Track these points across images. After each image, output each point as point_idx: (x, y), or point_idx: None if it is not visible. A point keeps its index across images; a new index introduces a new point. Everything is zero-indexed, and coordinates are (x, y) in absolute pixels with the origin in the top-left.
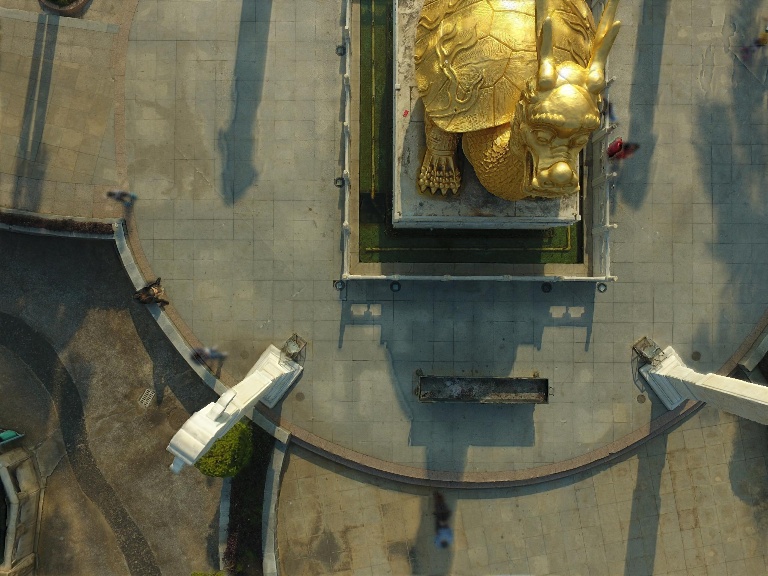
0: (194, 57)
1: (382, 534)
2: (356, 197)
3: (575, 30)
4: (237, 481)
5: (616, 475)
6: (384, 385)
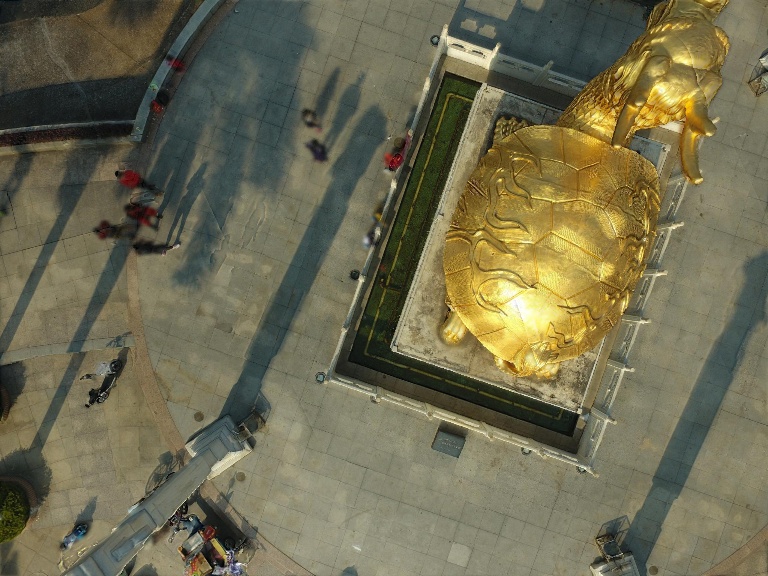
0: (767, 407)
1: None
2: None
3: (513, 221)
4: None
5: None
6: None
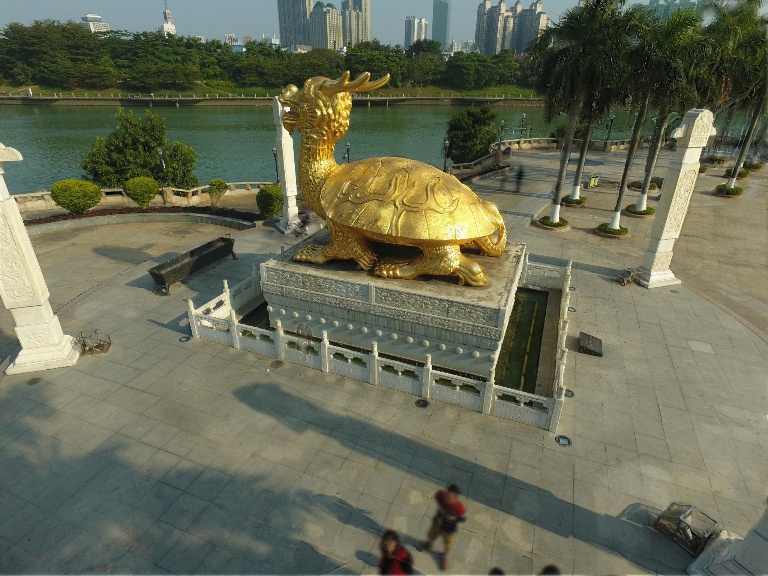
0: None
1: (164, 244)
2: None
3: None
4: (252, 213)
5: None
6: None
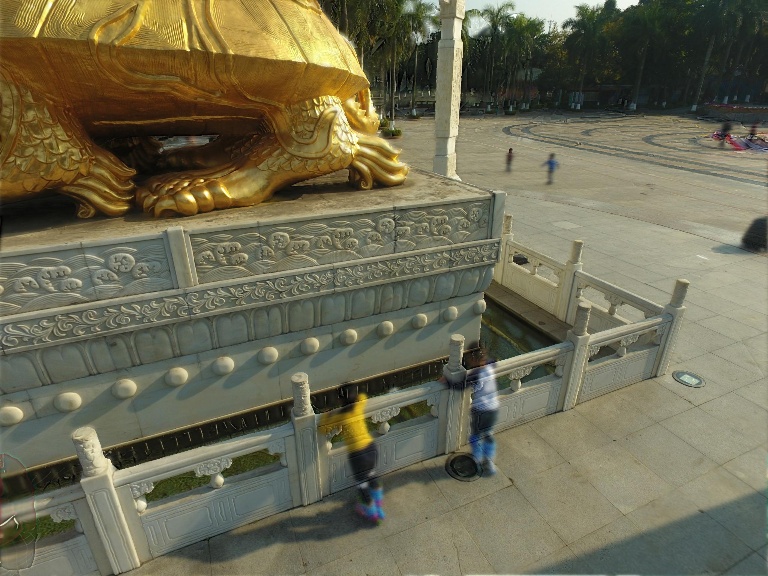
0: None
1: None
2: None
3: None
4: None
5: None
6: None
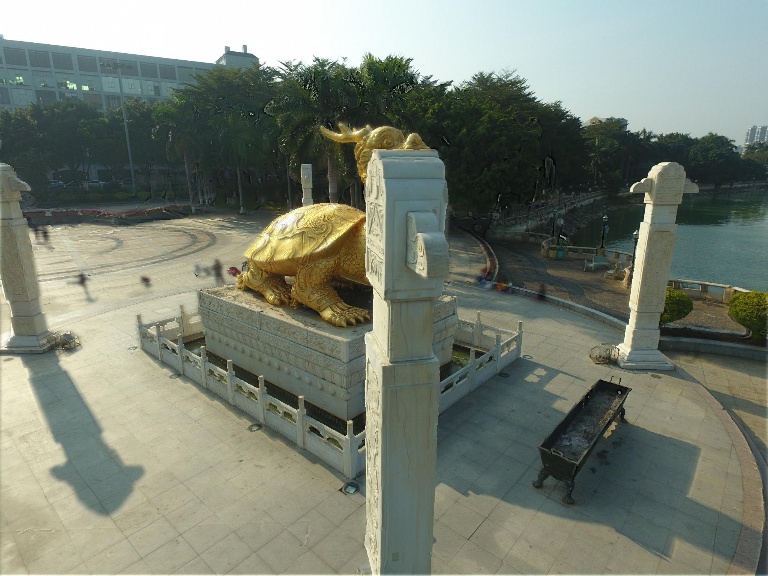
0: None
1: None
2: None
3: None
4: None
5: (762, 429)
6: (535, 529)
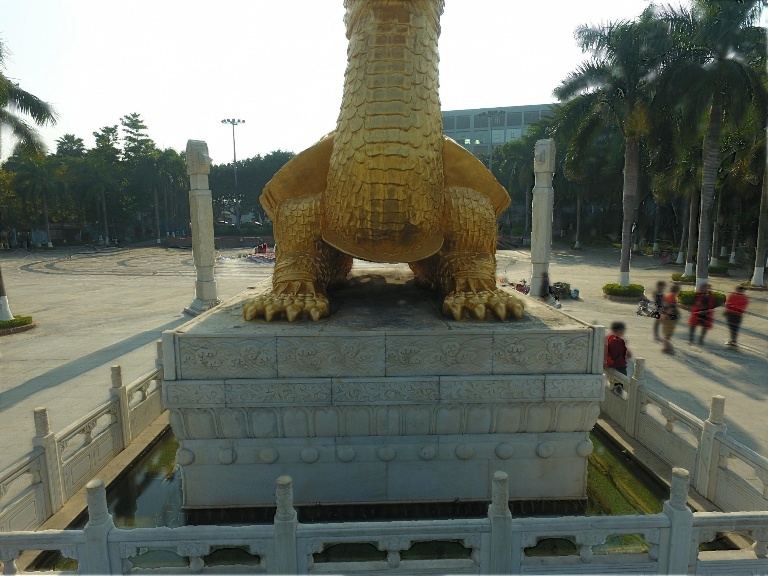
0: None
1: None
2: (123, 462)
3: None
4: None
5: None
6: None
